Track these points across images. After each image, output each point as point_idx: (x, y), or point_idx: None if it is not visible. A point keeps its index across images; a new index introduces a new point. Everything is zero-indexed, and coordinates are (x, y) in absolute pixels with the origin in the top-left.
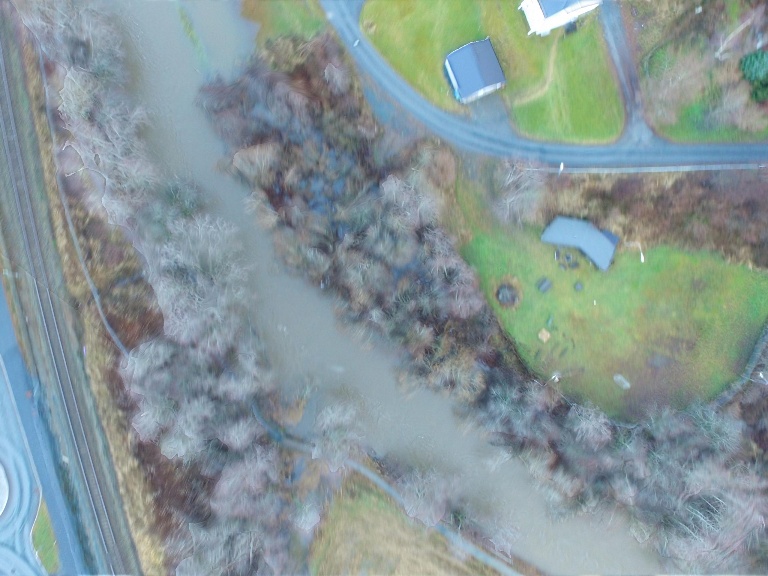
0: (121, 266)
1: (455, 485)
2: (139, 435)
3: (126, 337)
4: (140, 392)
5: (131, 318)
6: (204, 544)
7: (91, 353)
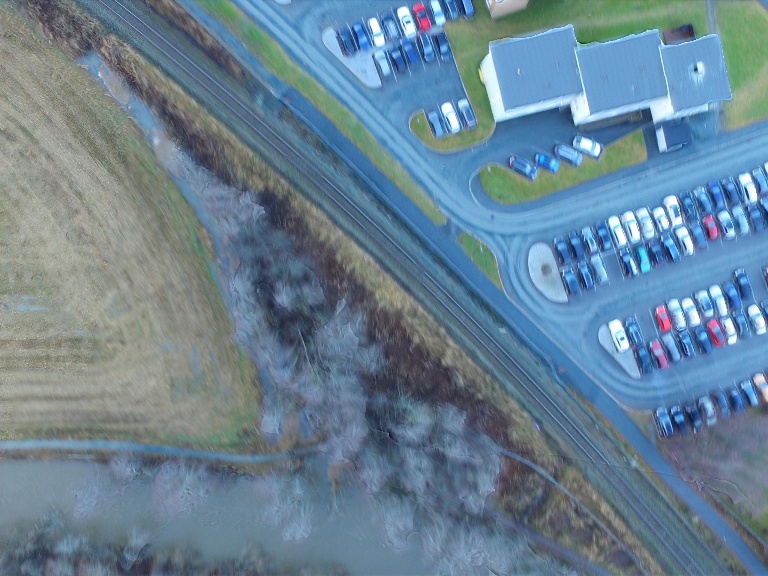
0: (548, 515)
1: (160, 507)
2: (455, 388)
3: (511, 461)
4: (473, 459)
5: (516, 479)
6: (348, 365)
7: (532, 431)
